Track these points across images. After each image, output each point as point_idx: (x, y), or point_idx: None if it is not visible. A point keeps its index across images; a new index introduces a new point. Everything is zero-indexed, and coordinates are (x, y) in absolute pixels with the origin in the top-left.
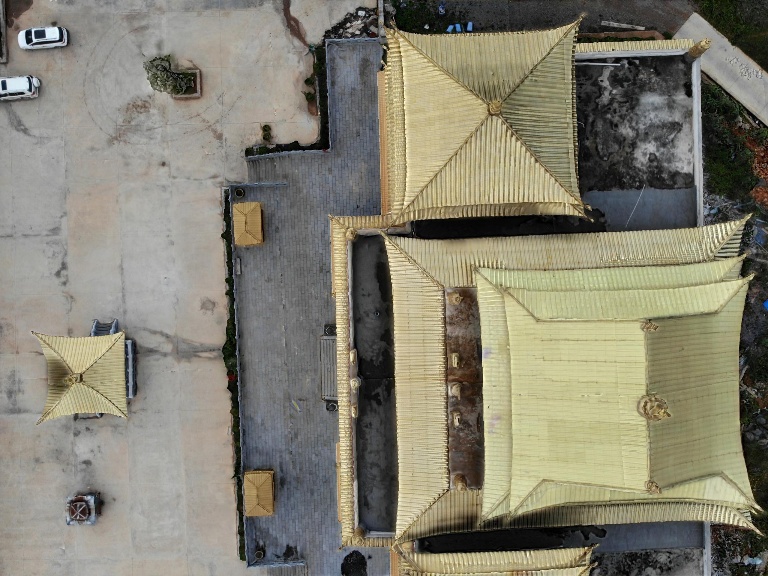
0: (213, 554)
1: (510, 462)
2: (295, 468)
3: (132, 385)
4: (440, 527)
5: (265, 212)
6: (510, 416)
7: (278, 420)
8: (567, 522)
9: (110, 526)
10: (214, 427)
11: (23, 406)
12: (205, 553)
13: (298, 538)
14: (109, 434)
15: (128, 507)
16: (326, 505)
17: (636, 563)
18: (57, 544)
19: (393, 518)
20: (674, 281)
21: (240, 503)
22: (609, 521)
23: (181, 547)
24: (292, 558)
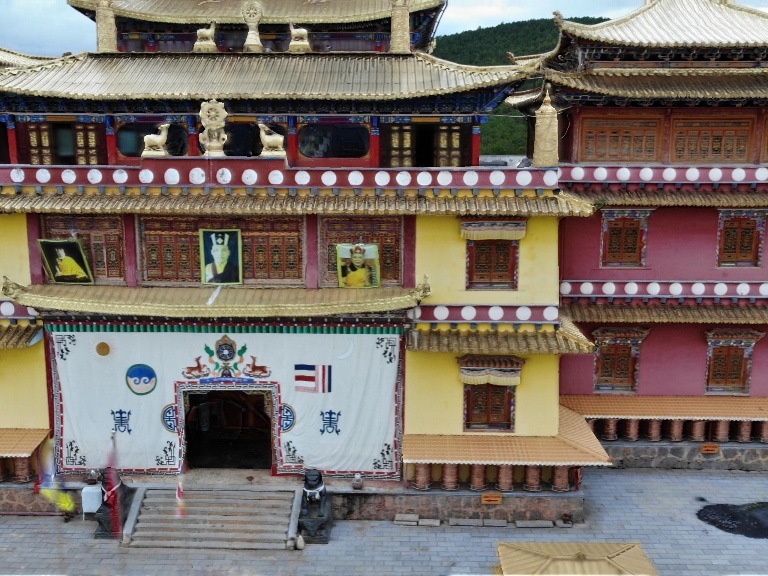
0: None
1: (362, 4)
2: None
3: None
4: None
5: None
6: (297, 4)
7: None
8: None
9: None
10: None
11: None
12: None
13: None
14: None
15: None
16: None
17: None
18: None
19: None
20: None
21: None
22: None
23: None
24: None
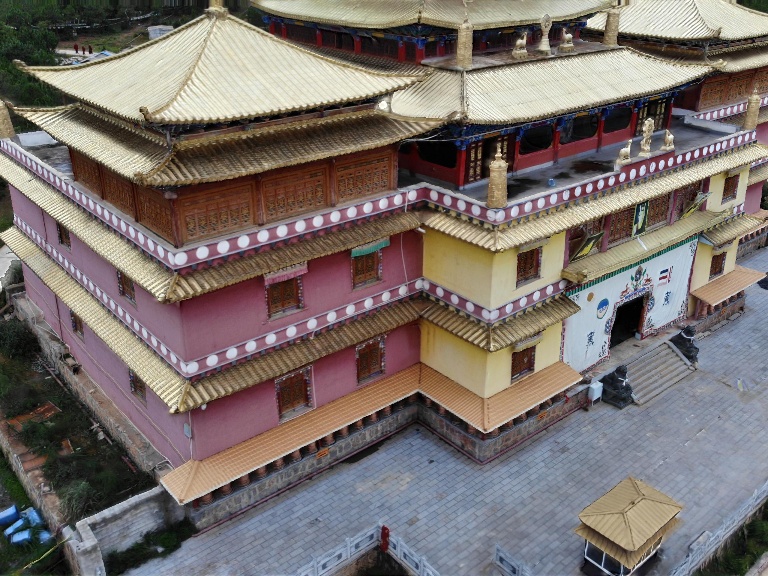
0: None
1: None
2: None
3: None
4: None
5: (579, 564)
6: (520, 2)
7: None
8: None
9: None
10: None
11: None
12: None
13: None
14: None
15: None
16: None
17: None
18: None
19: (700, 135)
20: (294, 3)
21: None
22: None
23: None
24: None
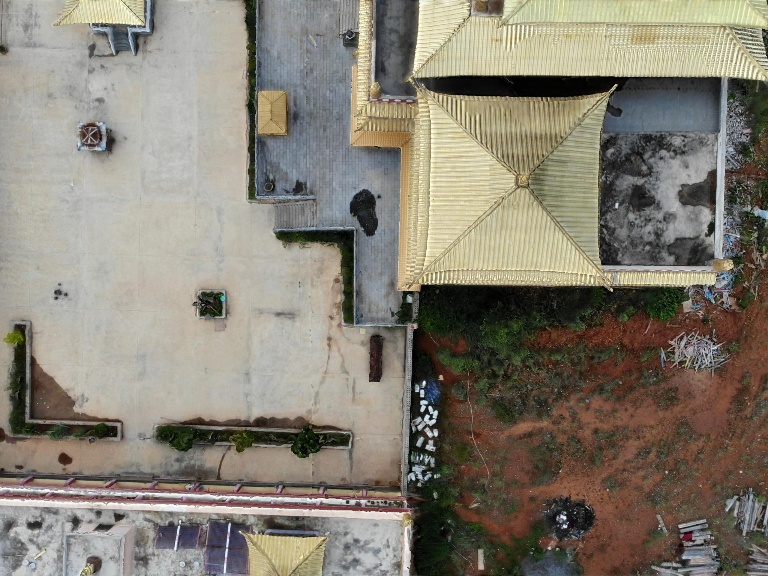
0: (222, 198)
1: None
2: (309, 103)
3: (149, 19)
4: (458, 67)
5: None
6: None
7: (294, 54)
8: (585, 71)
9: (120, 164)
10: (229, 70)
11: (39, 40)
12: (214, 197)
13: (308, 174)
14: (123, 72)
15: (139, 146)
16: (338, 142)
17: (650, 145)
18: (66, 181)
19: (409, 86)
20: None
21: (252, 141)
22: (627, 72)
23: (190, 189)
24: (301, 194)
